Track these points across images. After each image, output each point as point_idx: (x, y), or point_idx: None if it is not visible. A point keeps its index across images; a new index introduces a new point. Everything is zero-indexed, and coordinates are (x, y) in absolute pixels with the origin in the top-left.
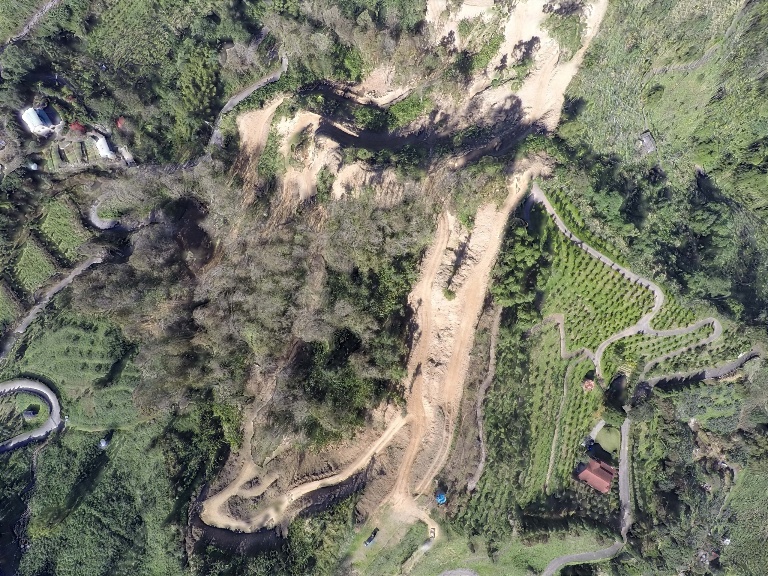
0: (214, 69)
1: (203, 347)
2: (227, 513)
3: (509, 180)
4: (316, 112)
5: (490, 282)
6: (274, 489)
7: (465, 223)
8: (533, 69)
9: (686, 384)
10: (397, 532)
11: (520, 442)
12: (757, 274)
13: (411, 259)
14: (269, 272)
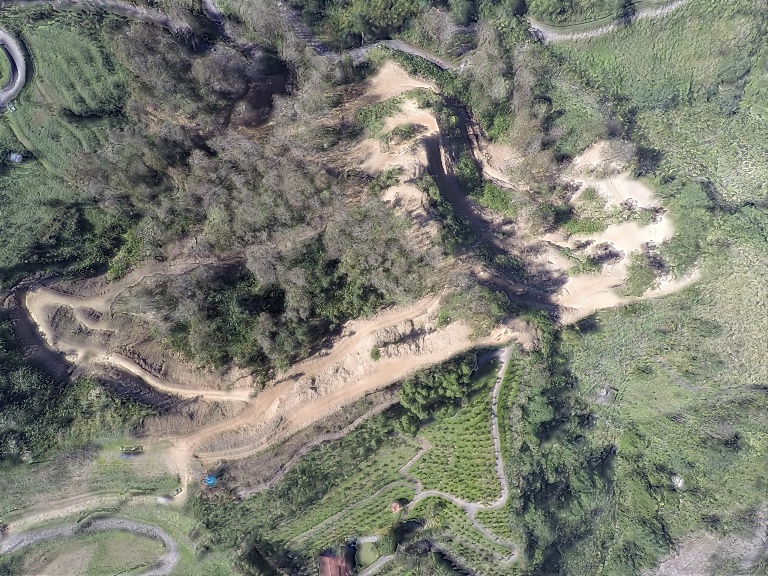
0: (410, 7)
1: (173, 182)
2: (50, 313)
3: (501, 324)
4: (439, 124)
5: (410, 377)
6: (104, 336)
7: (441, 319)
8: (599, 271)
9: (453, 573)
10: (154, 465)
11: (307, 496)
12: (574, 550)
13: (380, 299)
14: (279, 191)
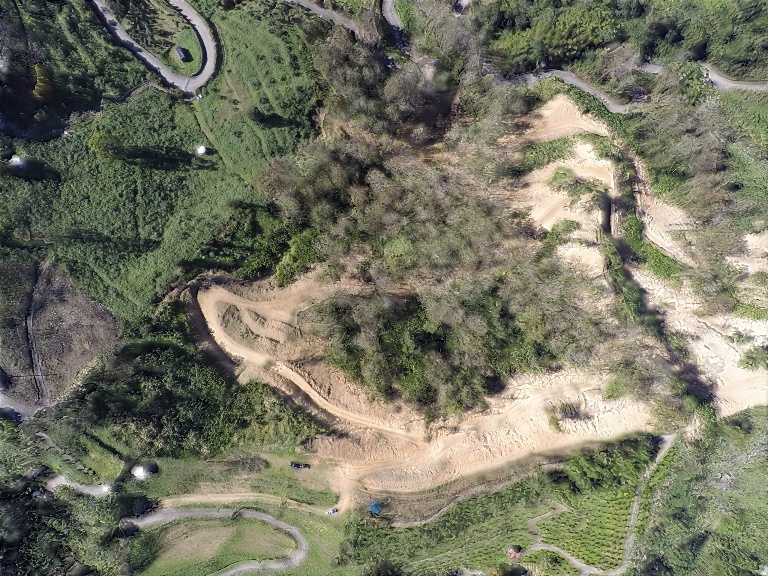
0: (593, 41)
1: (349, 200)
2: (221, 313)
3: None
4: (615, 180)
5: (586, 456)
6: (271, 346)
7: (618, 401)
8: (756, 365)
9: None
10: (317, 483)
11: None
12: None
13: (557, 368)
14: (468, 237)
